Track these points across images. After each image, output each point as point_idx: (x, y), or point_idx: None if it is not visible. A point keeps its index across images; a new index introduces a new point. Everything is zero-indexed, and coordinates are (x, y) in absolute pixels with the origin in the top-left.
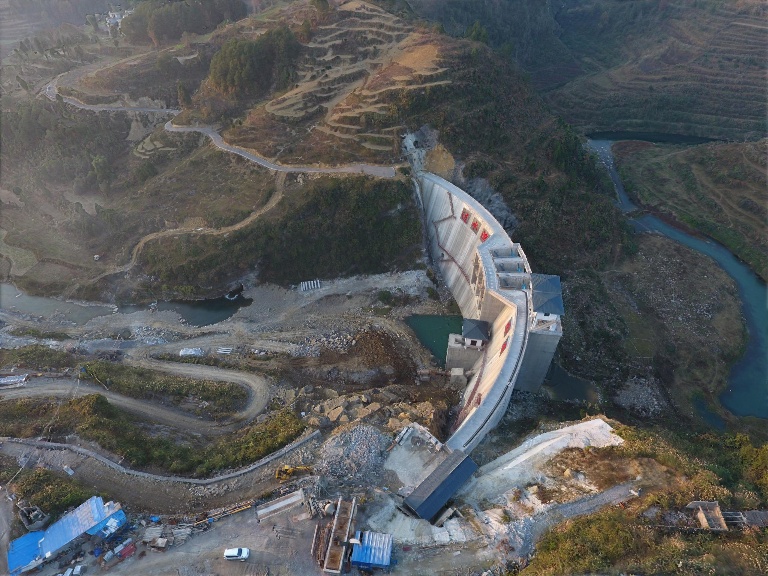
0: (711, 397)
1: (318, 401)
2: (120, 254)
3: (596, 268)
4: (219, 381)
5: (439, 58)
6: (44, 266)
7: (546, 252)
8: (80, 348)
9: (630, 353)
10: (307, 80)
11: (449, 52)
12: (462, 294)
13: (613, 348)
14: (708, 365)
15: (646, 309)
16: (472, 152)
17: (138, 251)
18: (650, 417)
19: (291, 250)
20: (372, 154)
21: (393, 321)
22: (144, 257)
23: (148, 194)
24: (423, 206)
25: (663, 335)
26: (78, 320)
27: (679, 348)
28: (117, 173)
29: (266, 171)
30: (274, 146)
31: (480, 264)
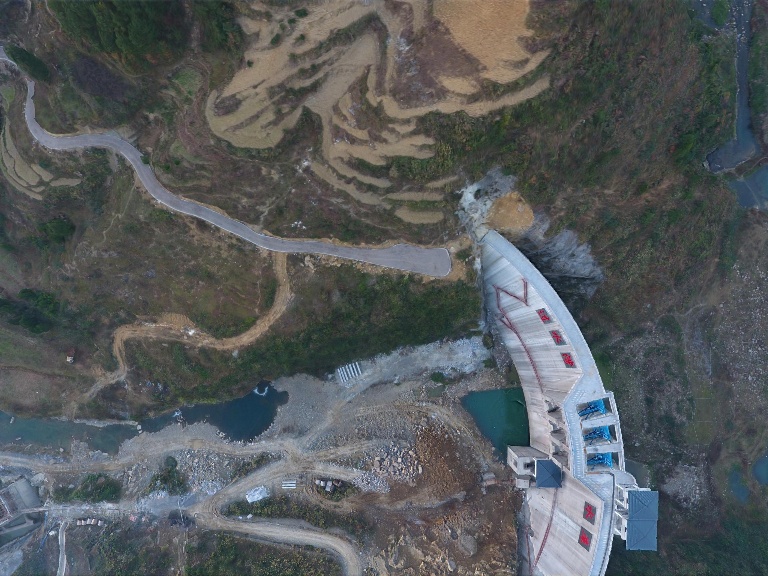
0: (747, 469)
1: (409, 573)
2: (97, 352)
3: (680, 311)
4: (306, 547)
5: (532, 29)
6: (11, 377)
7: (629, 311)
8: (147, 521)
9: (689, 442)
10: (265, 46)
11: (553, 7)
12: (524, 370)
13: (674, 434)
14: (757, 432)
15: (719, 370)
16: (561, 191)
17: (121, 353)
18: (689, 509)
19: (321, 353)
20: (414, 232)
21: (450, 410)
22: (133, 360)
23: (85, 275)
24: (481, 264)
25: (727, 408)
26: (106, 447)
27: (737, 419)
28: (0, 208)
29: (253, 248)
30: (251, 206)
31: (565, 429)
